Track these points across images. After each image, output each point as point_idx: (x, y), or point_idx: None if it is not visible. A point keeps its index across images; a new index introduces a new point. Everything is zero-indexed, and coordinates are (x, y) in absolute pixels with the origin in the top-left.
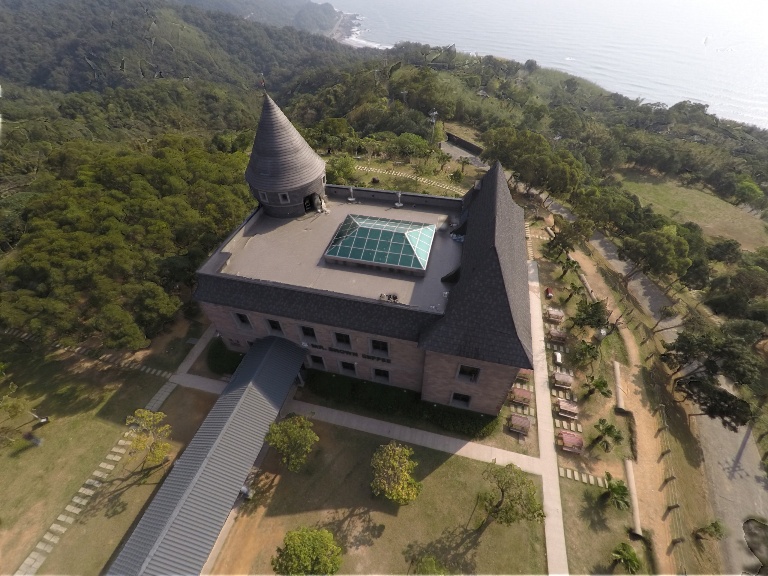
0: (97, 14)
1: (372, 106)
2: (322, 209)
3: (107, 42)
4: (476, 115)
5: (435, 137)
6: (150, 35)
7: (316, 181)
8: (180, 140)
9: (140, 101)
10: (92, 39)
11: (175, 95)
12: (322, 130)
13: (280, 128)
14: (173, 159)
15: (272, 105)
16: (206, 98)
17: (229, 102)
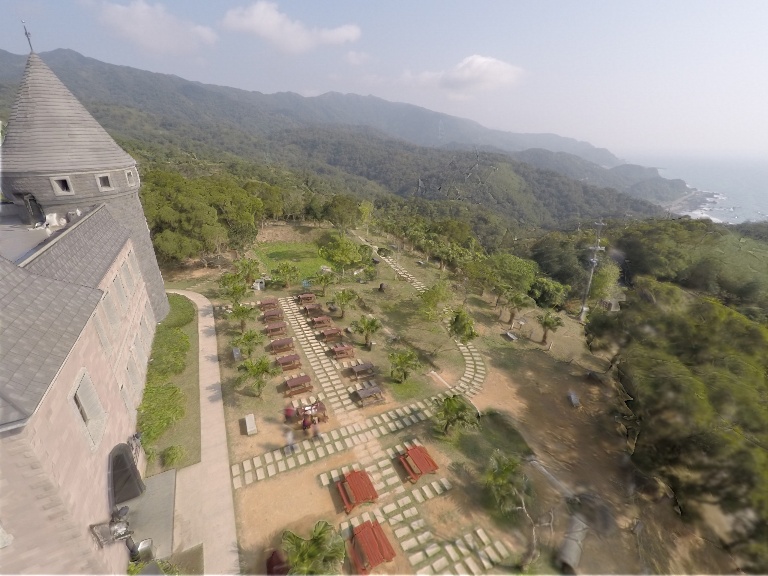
0: (446, 156)
1: (570, 240)
2: (42, 225)
3: (441, 173)
4: (743, 292)
5: (598, 289)
6: (470, 171)
7: (34, 177)
8: (259, 186)
9: (426, 209)
10: (434, 170)
11: (455, 211)
12: (431, 229)
13: (23, 94)
14: (184, 181)
15: (29, 65)
16: (479, 219)
17: (496, 227)
